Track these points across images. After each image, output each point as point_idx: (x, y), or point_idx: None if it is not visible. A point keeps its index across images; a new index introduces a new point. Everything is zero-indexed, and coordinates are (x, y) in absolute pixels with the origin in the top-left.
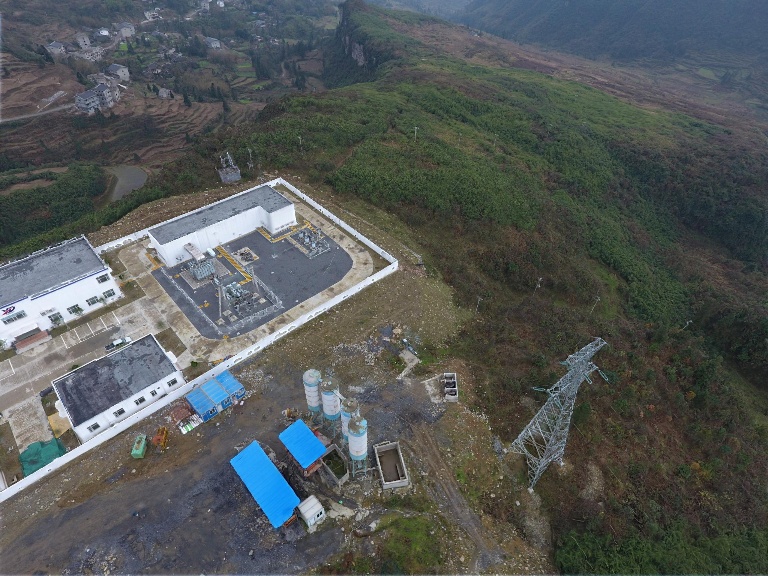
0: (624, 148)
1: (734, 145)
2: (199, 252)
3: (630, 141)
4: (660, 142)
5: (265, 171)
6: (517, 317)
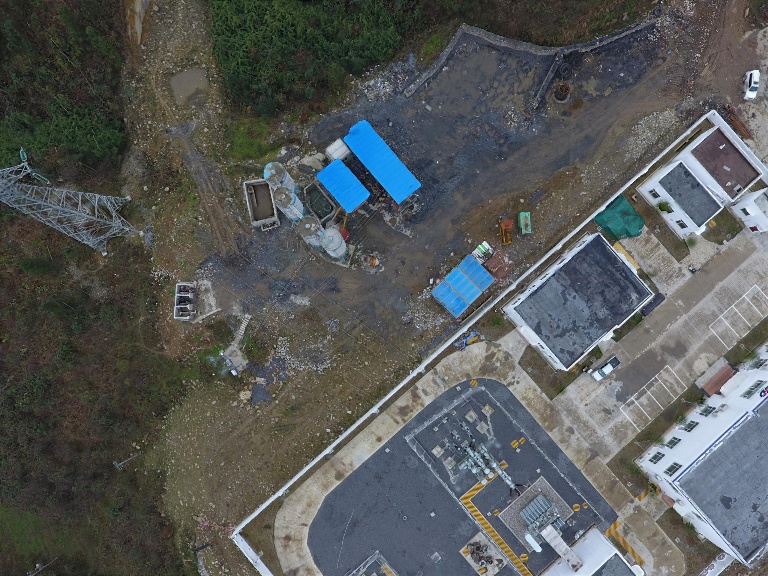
0: None
1: None
2: (553, 544)
3: None
4: None
5: None
6: (78, 451)
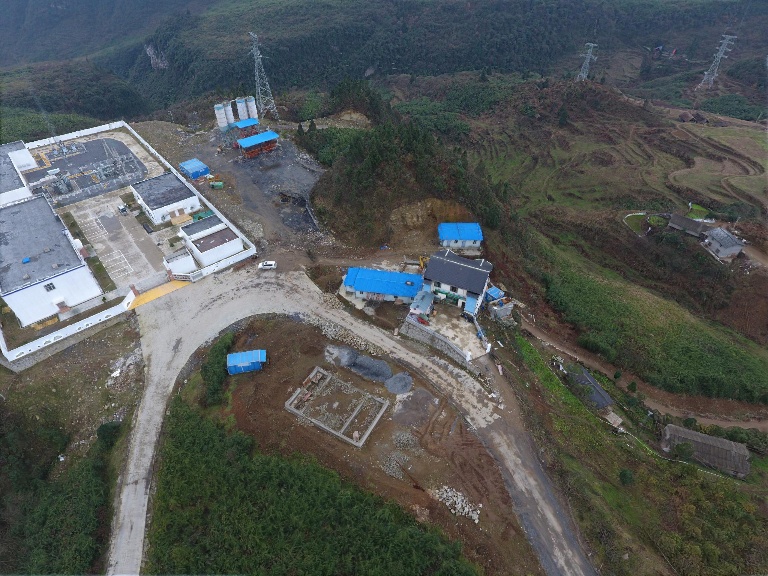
0: (7, 99)
1: (56, 67)
2: (47, 177)
3: (1, 94)
4: (18, 85)
5: None
6: (184, 117)
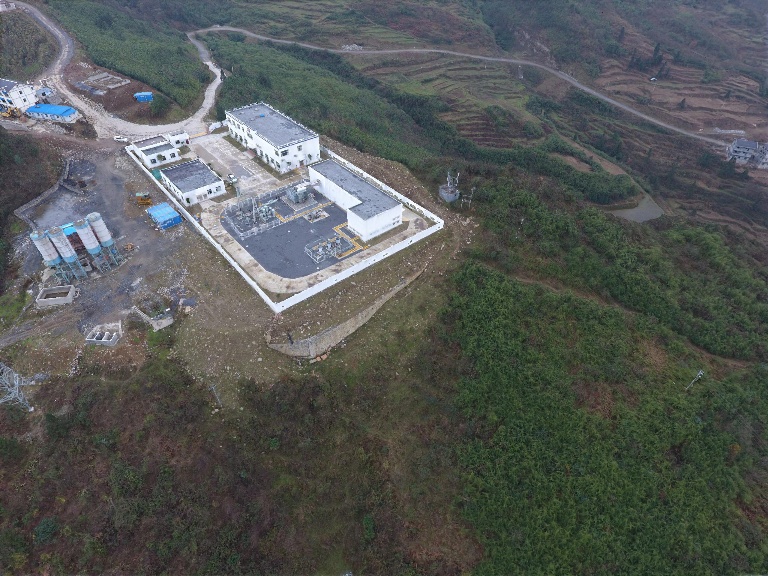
0: None
1: None
2: (305, 185)
3: None
4: None
5: (474, 217)
6: None
